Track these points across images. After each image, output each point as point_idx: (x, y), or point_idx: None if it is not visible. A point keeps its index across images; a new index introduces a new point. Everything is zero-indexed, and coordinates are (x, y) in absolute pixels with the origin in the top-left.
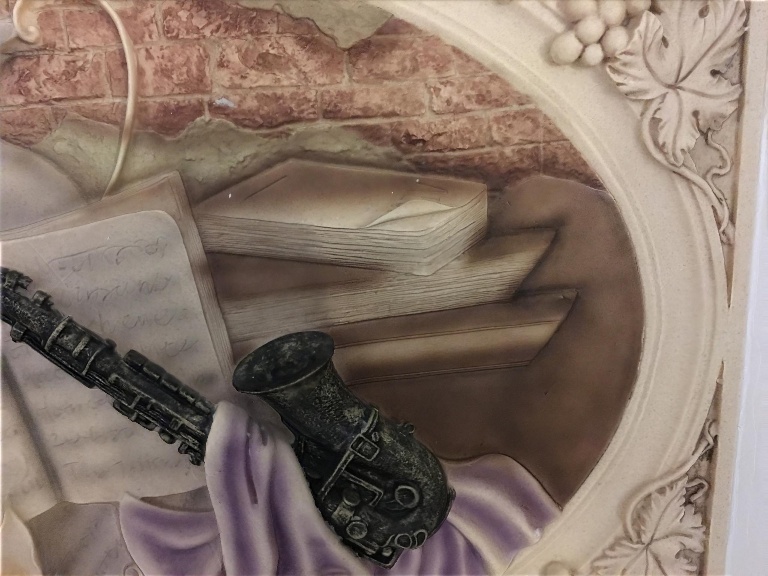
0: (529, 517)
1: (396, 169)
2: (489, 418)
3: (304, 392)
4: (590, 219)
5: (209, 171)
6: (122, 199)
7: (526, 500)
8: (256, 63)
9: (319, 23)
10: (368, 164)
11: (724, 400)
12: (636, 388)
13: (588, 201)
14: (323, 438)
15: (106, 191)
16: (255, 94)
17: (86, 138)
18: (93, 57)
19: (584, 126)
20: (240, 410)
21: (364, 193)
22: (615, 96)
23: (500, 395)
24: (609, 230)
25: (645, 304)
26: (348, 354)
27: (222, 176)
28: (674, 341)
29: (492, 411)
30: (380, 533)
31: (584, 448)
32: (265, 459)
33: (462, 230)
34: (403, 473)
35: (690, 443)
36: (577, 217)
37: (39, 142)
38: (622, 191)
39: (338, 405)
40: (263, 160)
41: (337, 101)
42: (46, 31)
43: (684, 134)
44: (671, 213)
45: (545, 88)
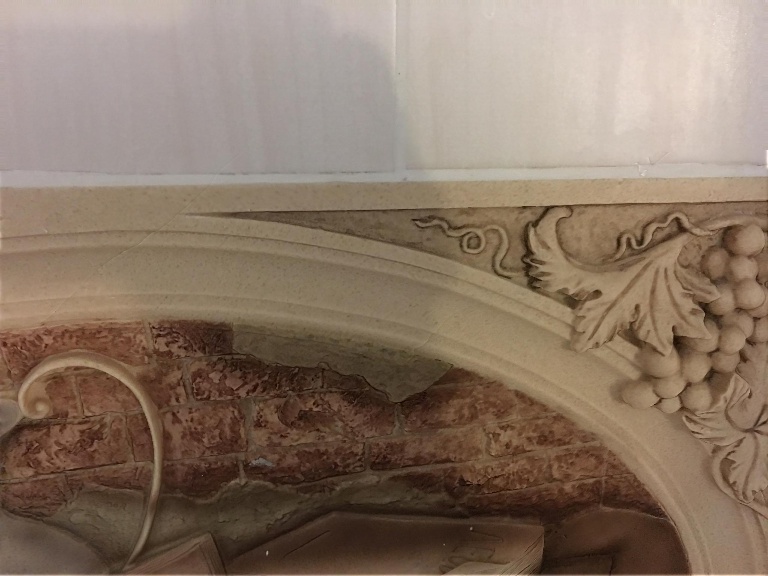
0: None
1: (448, 515)
2: None
3: None
4: (648, 544)
5: (244, 530)
6: (149, 573)
7: None
8: (297, 419)
9: (370, 380)
10: (418, 512)
11: None
12: None
13: (648, 529)
14: None
15: (130, 560)
16: (296, 452)
17: (106, 507)
18: (112, 423)
19: (650, 459)
20: None
21: (414, 547)
22: (687, 433)
23: None
24: (666, 552)
25: None
26: None
27: (258, 533)
28: None
29: None
30: None
31: None
32: None
33: (516, 575)
34: None
35: None
36: (635, 543)
37: (53, 515)
38: (684, 517)
39: None
40: (304, 515)
41: (386, 453)
42: (56, 401)
43: (757, 477)
44: (732, 533)
45: (612, 426)
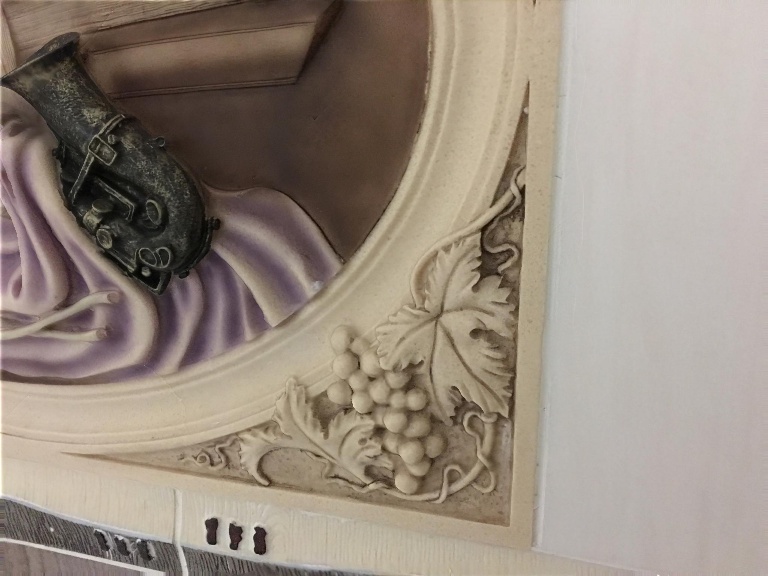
0: (309, 267)
1: None
2: (263, 148)
3: (39, 83)
4: None
5: None
6: None
7: (308, 248)
8: None
9: None
10: None
11: (530, 135)
12: (425, 119)
13: None
14: (69, 139)
15: None
16: None
17: None
18: None
19: None
20: (2, 105)
21: None
22: None
23: (271, 120)
24: None
25: (431, 6)
26: (110, 61)
27: None
28: (475, 58)
29: (267, 140)
30: (129, 247)
31: (366, 191)
32: (8, 148)
33: None
34: (148, 185)
35: (486, 191)
36: None
37: None
38: None
39: (76, 103)
40: None
41: None
42: None
43: None
44: None
45: None
